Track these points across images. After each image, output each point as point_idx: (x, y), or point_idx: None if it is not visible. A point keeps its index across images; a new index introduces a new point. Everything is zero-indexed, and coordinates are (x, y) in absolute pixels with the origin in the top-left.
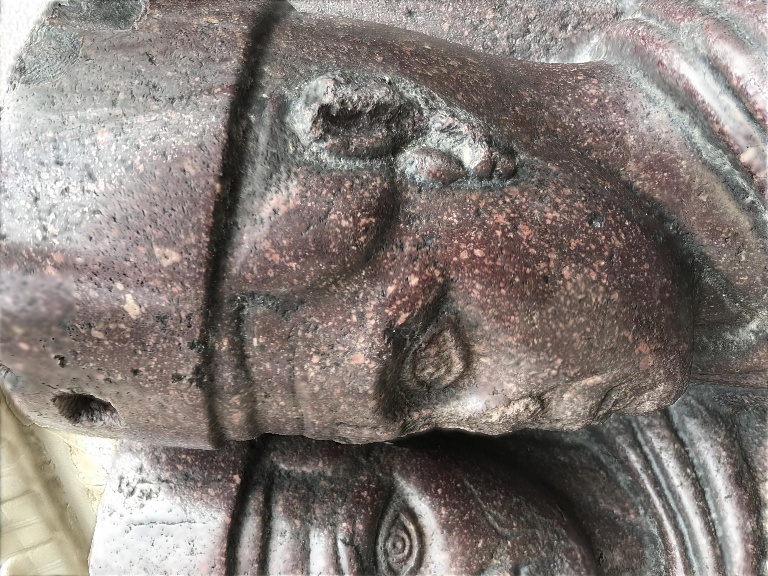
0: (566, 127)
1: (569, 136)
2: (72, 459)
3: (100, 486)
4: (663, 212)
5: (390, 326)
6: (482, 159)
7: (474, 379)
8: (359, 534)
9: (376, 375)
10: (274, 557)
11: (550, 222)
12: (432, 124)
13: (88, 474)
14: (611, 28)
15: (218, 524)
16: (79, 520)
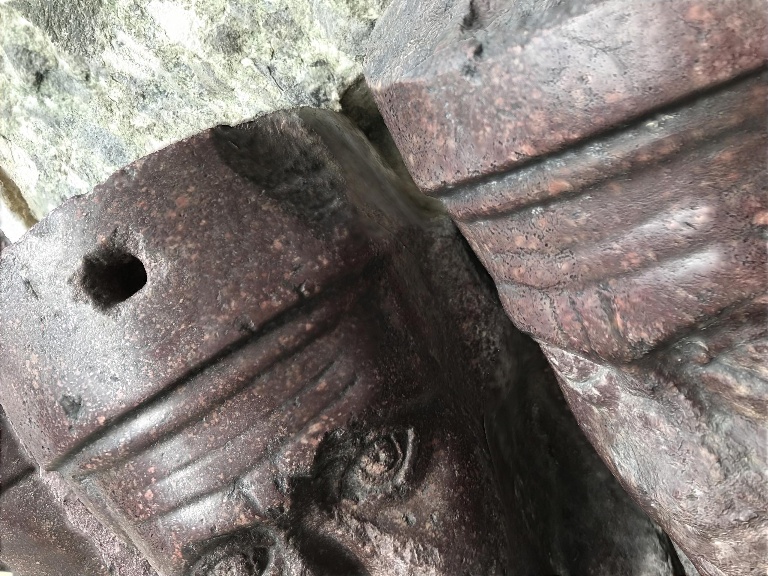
0: None
1: None
2: None
3: None
4: None
5: None
6: None
7: None
8: None
9: None
10: None
11: None
12: None
13: None
14: None
15: None
16: None
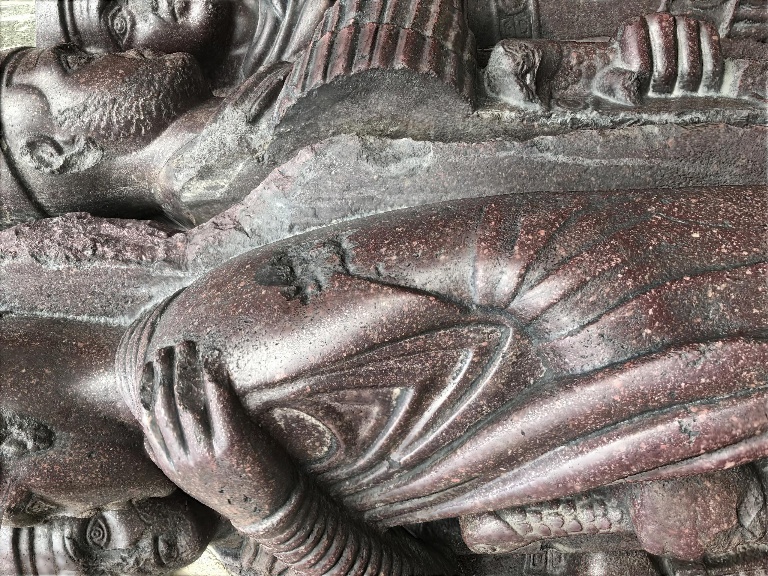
0: (88, 404)
1: (90, 408)
2: None
3: None
4: (141, 430)
5: (9, 508)
6: (31, 447)
7: (66, 505)
8: (75, 533)
9: (12, 521)
10: (37, 546)
11: (68, 462)
12: (12, 431)
13: None
14: None
15: (7, 536)
16: None
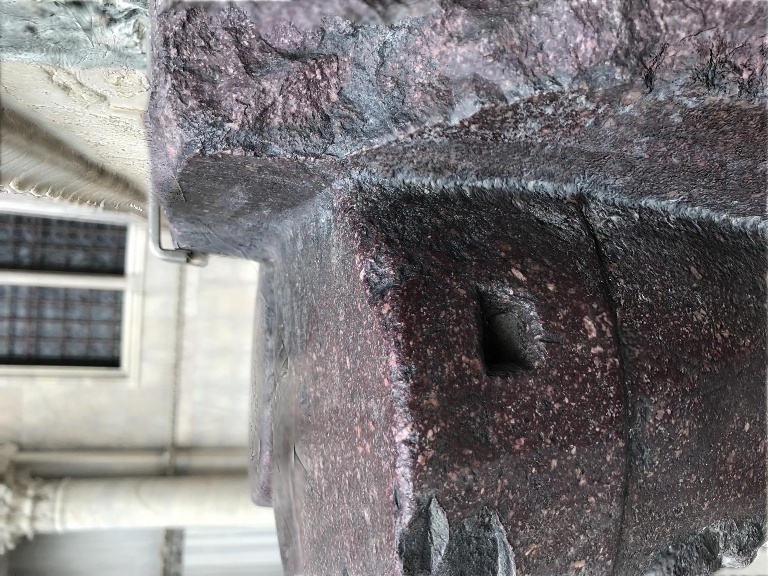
0: None
1: None
2: (8, 92)
3: (46, 107)
4: None
5: None
6: None
7: None
8: None
9: None
10: None
11: None
12: None
13: (31, 102)
14: None
15: None
16: (17, 112)
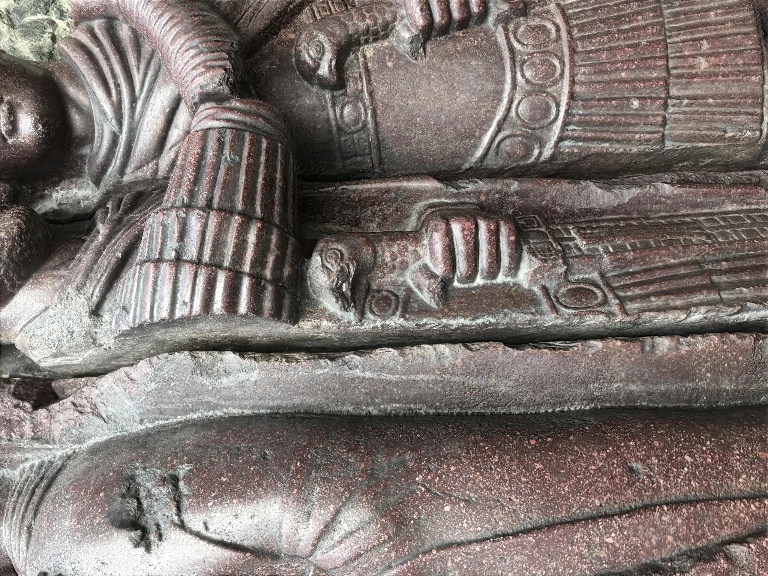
0: None
1: None
2: None
3: None
4: None
5: None
6: None
7: None
8: None
9: None
10: None
11: None
12: None
13: None
14: None
15: None
16: None
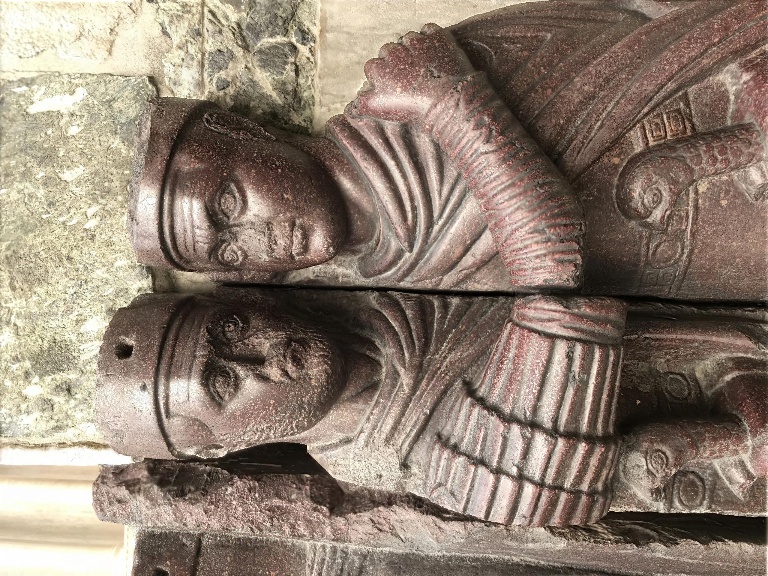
0: None
1: None
2: None
3: None
4: None
5: None
6: None
7: None
8: None
9: None
10: None
11: None
12: None
13: None
14: (307, 575)
15: None
16: None
